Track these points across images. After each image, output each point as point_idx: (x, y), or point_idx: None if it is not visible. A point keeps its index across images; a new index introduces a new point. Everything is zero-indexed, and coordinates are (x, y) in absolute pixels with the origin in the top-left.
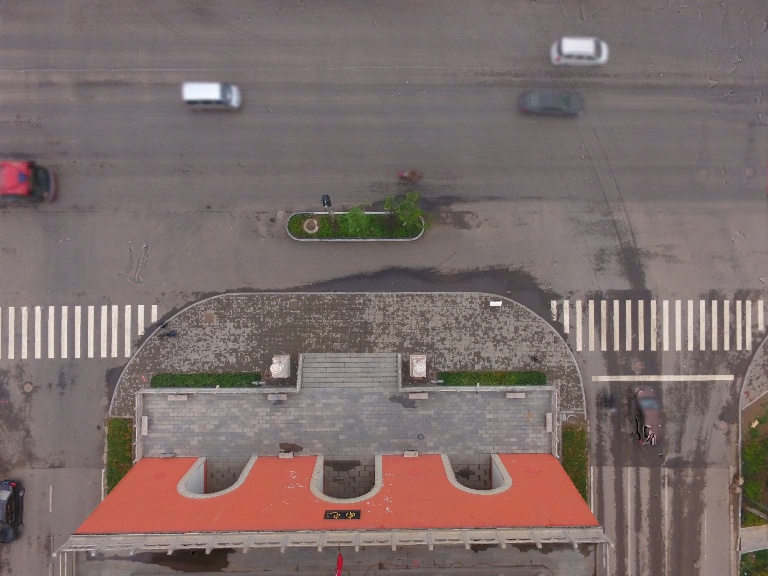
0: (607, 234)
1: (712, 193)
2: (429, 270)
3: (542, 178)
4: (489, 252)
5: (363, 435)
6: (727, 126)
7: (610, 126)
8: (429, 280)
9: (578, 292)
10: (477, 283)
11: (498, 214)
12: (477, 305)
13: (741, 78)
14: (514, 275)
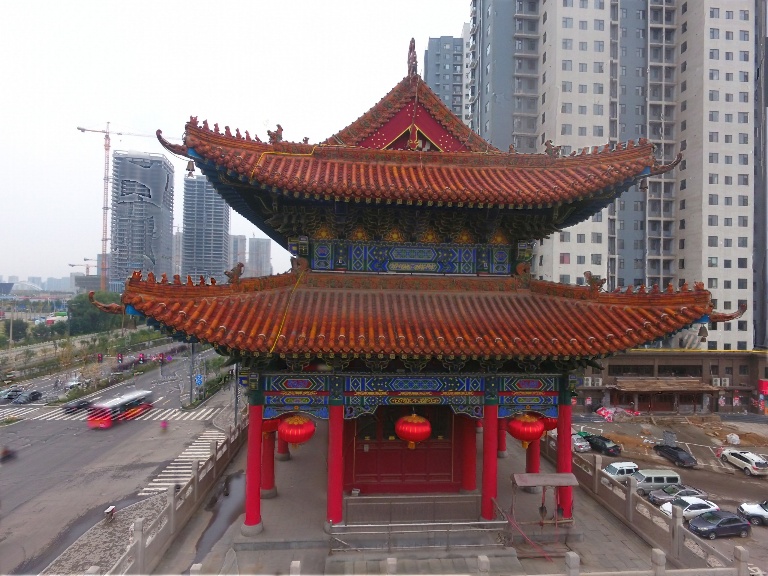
0: (100, 475)
1: (112, 445)
2: (21, 565)
3: (7, 501)
4: (49, 527)
5: None
6: (68, 442)
7: (4, 474)
8: (35, 565)
9: (140, 485)
10: (76, 533)
11: (12, 522)
12: (102, 531)
13: (39, 438)
14: (91, 513)
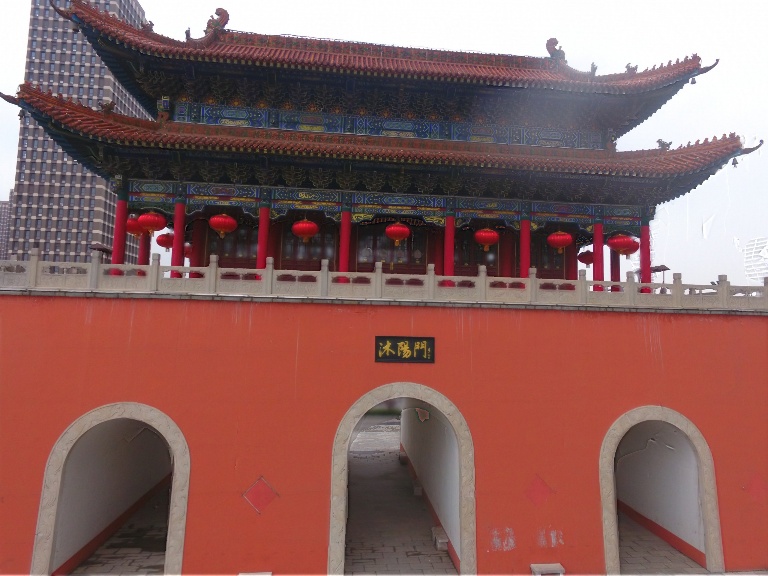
0: None
1: None
2: None
3: None
4: None
5: (384, 443)
6: None
7: None
8: None
9: None
10: None
11: None
12: None
13: None
14: None
